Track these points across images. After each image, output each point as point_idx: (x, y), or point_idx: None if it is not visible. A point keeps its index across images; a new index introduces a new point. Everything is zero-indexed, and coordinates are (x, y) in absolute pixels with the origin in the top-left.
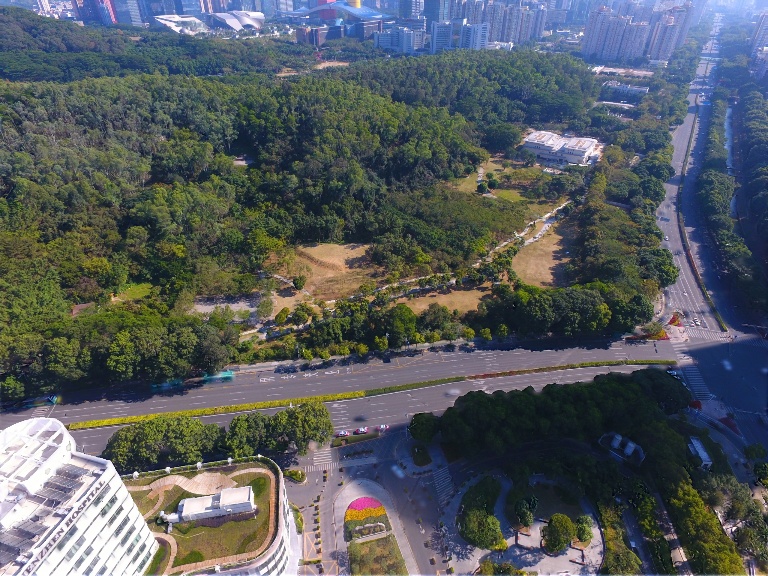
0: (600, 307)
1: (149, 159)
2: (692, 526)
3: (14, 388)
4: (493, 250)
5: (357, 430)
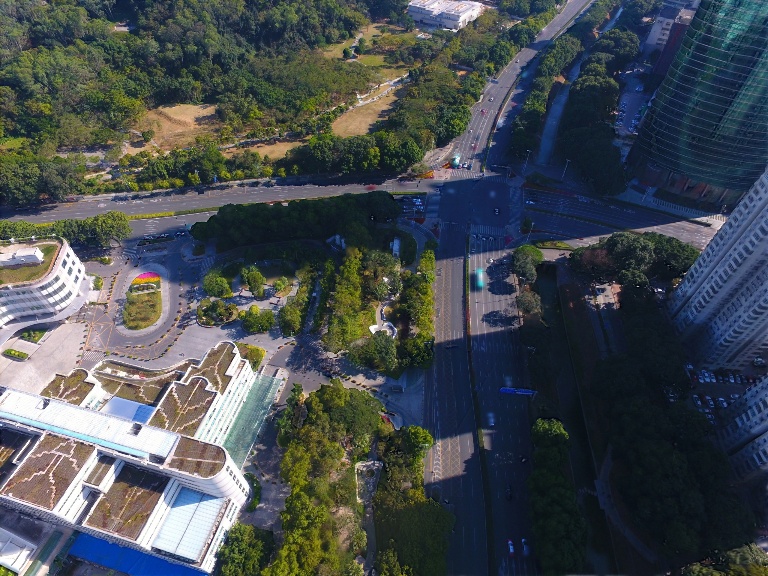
0: (370, 150)
1: (26, 24)
2: (340, 278)
3: None
4: (330, 110)
5: (159, 236)
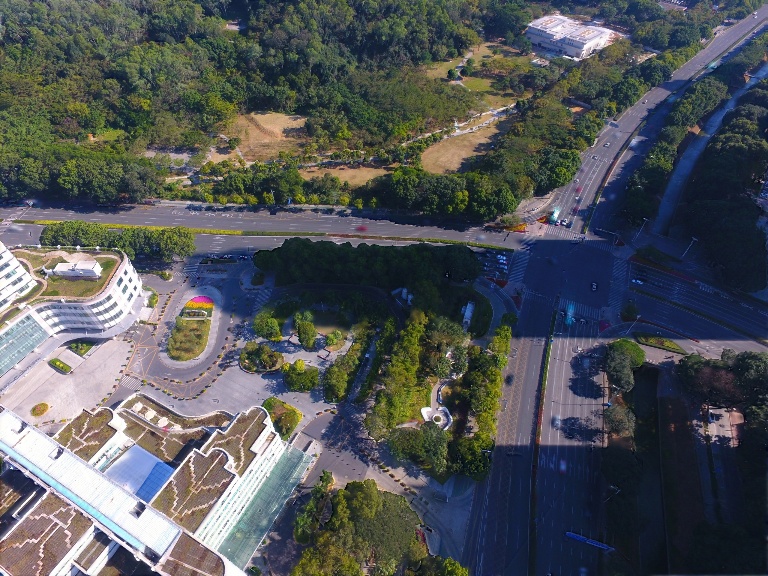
0: (458, 193)
1: (145, 17)
2: (398, 346)
3: (0, 190)
4: (422, 136)
5: (223, 256)
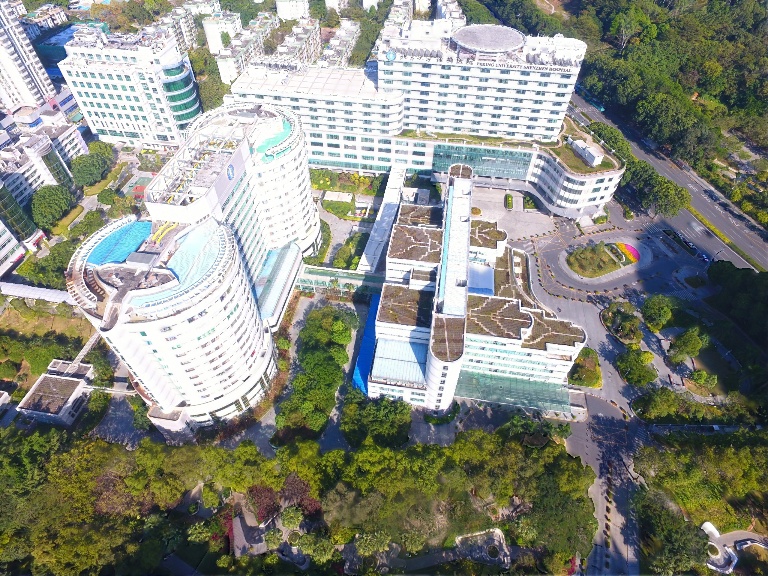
0: None
1: None
2: (765, 452)
3: (598, 87)
4: None
5: (689, 242)
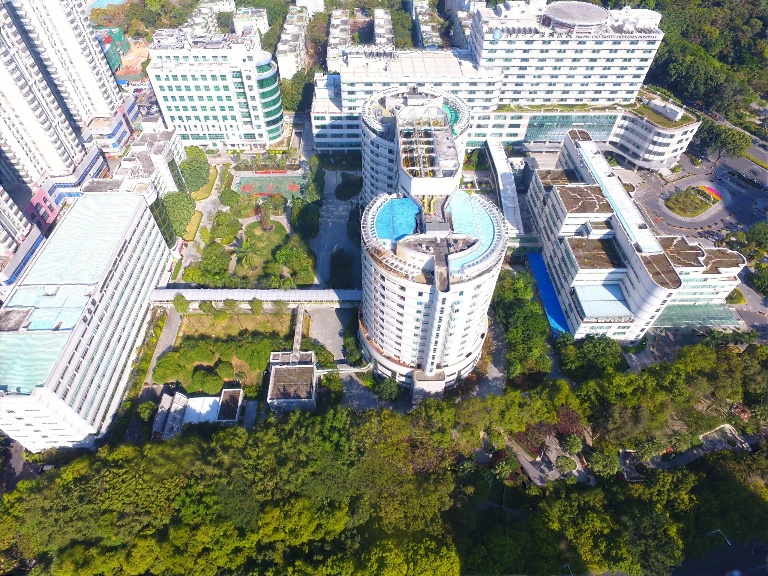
0: None
1: None
2: None
3: None
4: None
5: (752, 179)
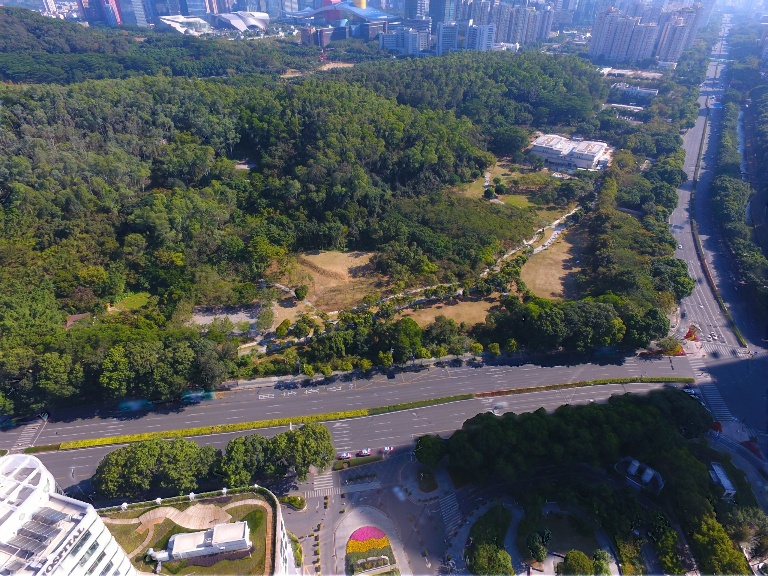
0: (614, 322)
1: (149, 163)
2: (718, 565)
3: (3, 405)
4: (501, 259)
5: (360, 452)
